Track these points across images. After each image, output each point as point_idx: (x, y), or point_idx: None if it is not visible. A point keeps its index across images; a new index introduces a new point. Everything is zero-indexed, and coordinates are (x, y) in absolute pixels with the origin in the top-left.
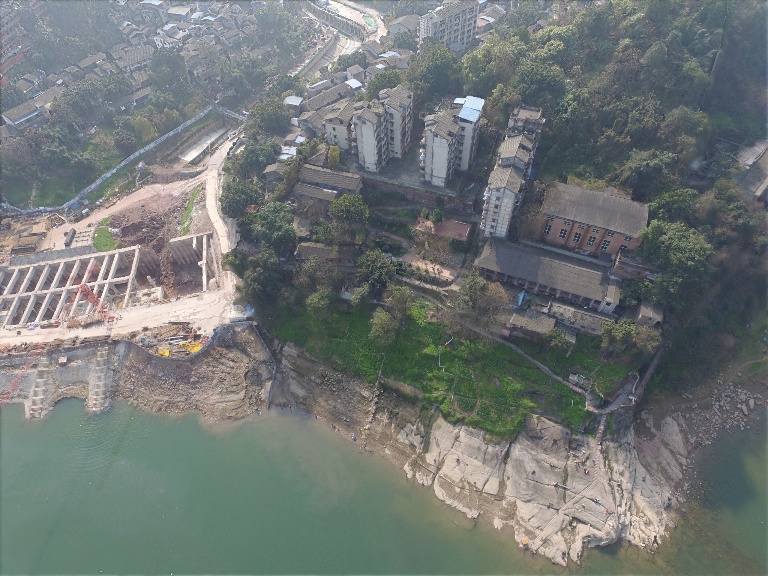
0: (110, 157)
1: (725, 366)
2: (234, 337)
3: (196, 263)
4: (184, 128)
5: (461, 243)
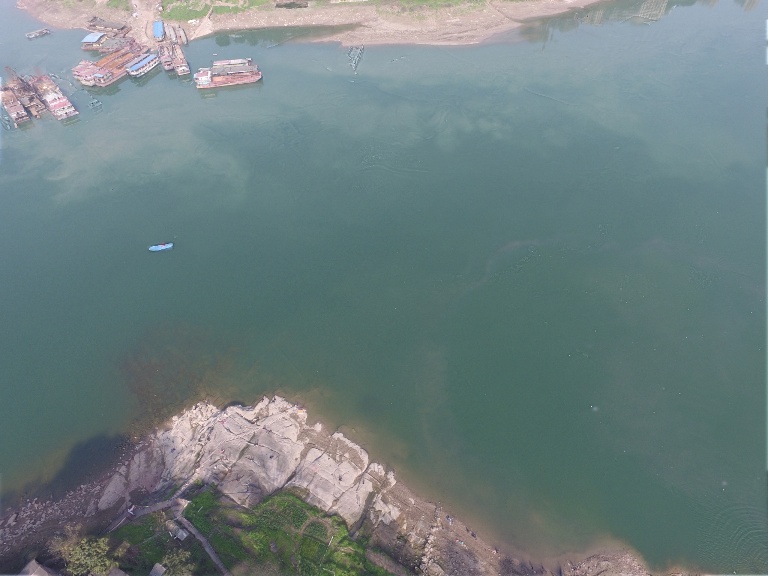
0: None
1: None
2: None
3: None
4: None
5: None
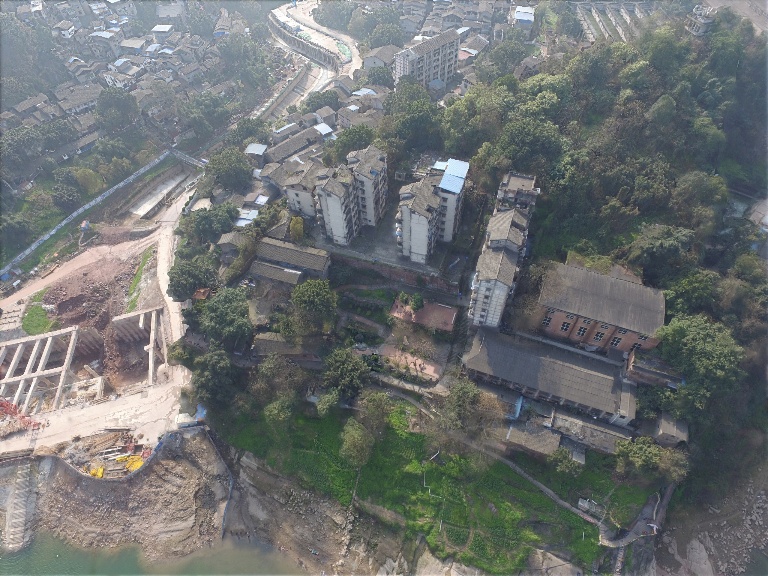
0: (49, 216)
1: (755, 470)
2: (183, 445)
3: (146, 340)
4: (136, 177)
5: (446, 333)
